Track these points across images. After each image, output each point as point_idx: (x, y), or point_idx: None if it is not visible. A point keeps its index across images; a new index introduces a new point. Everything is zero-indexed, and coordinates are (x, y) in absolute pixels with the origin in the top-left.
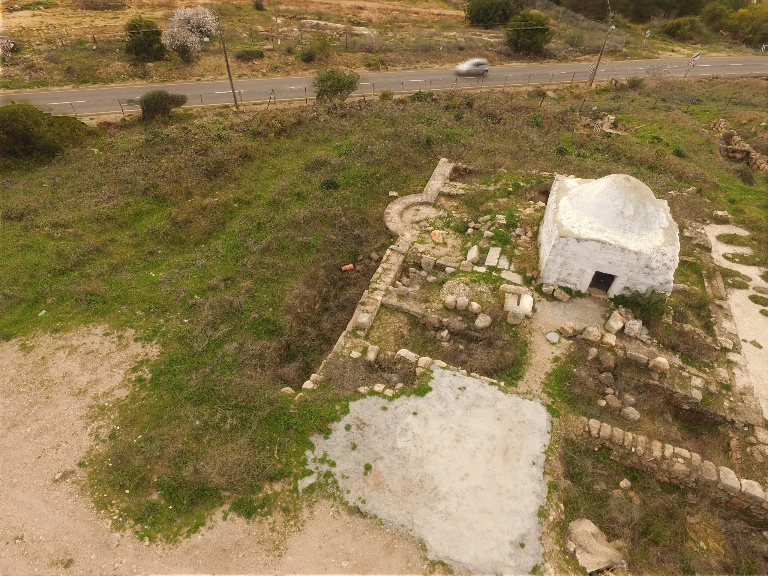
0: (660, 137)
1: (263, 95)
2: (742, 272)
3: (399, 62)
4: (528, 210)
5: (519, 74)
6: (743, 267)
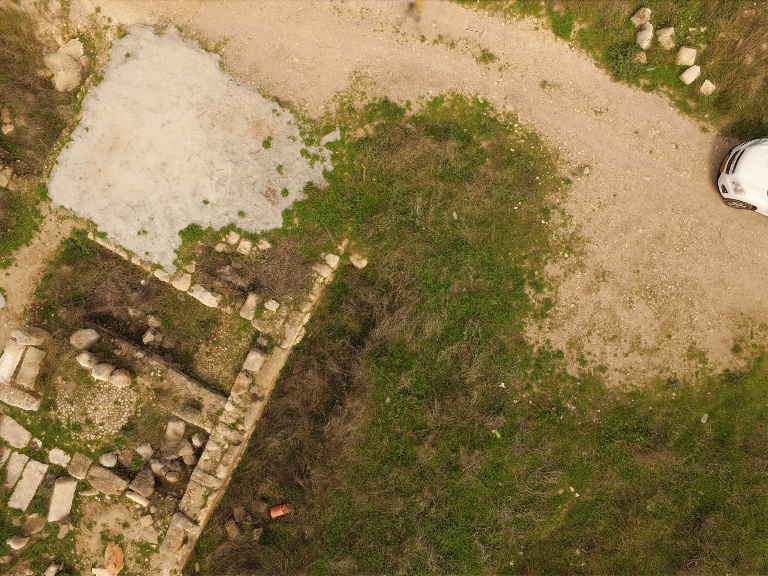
0: None
1: None
2: None
3: None
4: None
5: None
6: None
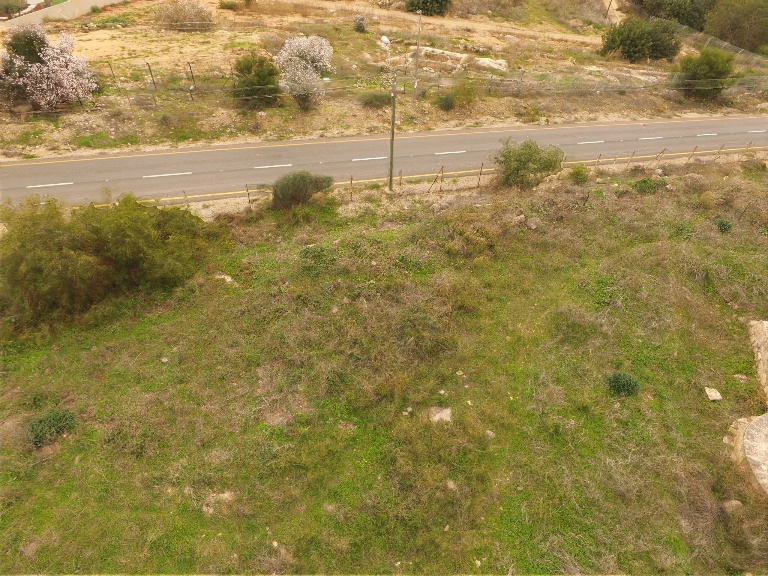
0: None
1: (415, 165)
2: None
3: (554, 110)
4: None
5: (713, 133)
6: None
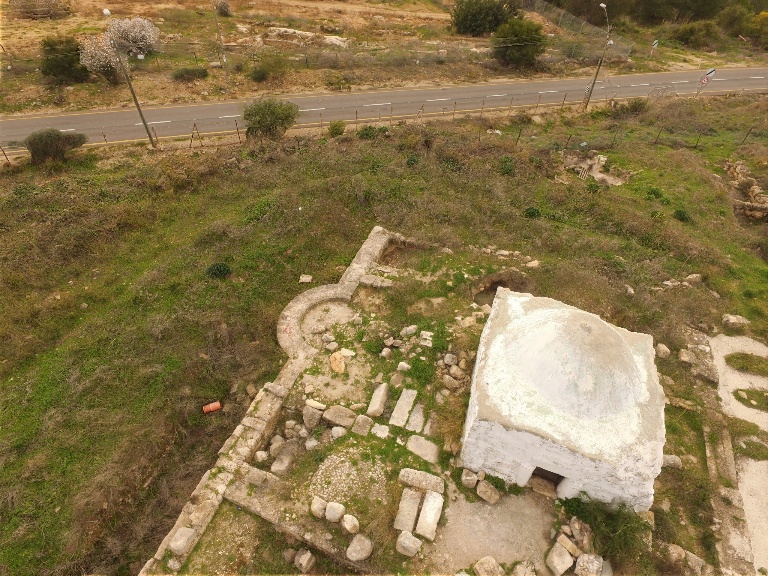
0: (659, 190)
1: None
2: (761, 426)
3: (367, 79)
4: (467, 321)
5: (503, 94)
6: (762, 416)
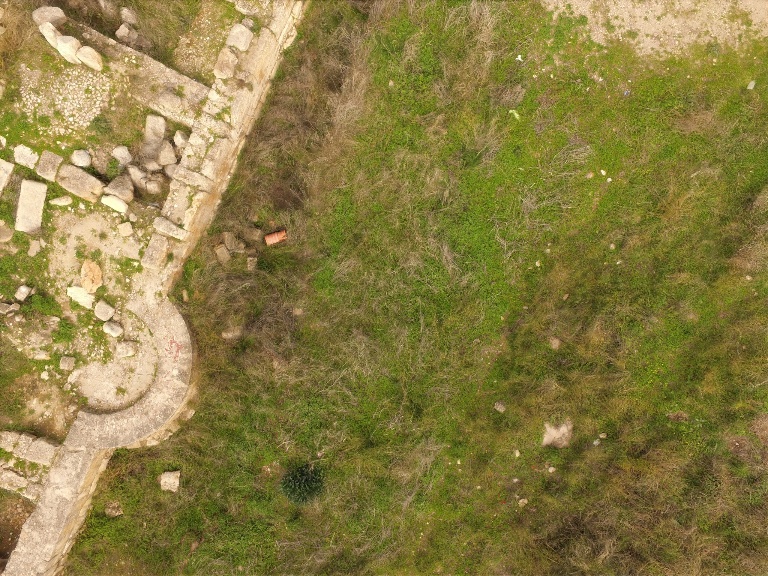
0: None
1: None
2: None
3: None
4: None
5: None
6: None
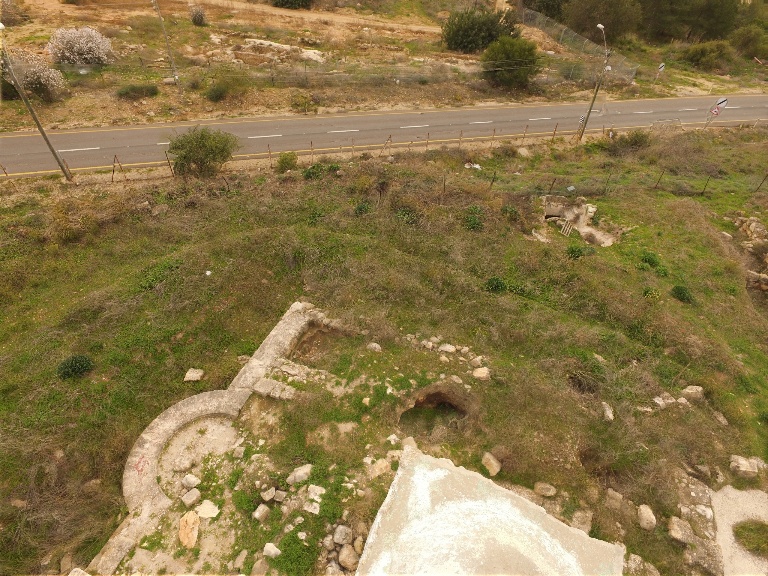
0: (656, 255)
1: None
2: None
3: (338, 100)
4: (378, 467)
5: (488, 121)
6: None
